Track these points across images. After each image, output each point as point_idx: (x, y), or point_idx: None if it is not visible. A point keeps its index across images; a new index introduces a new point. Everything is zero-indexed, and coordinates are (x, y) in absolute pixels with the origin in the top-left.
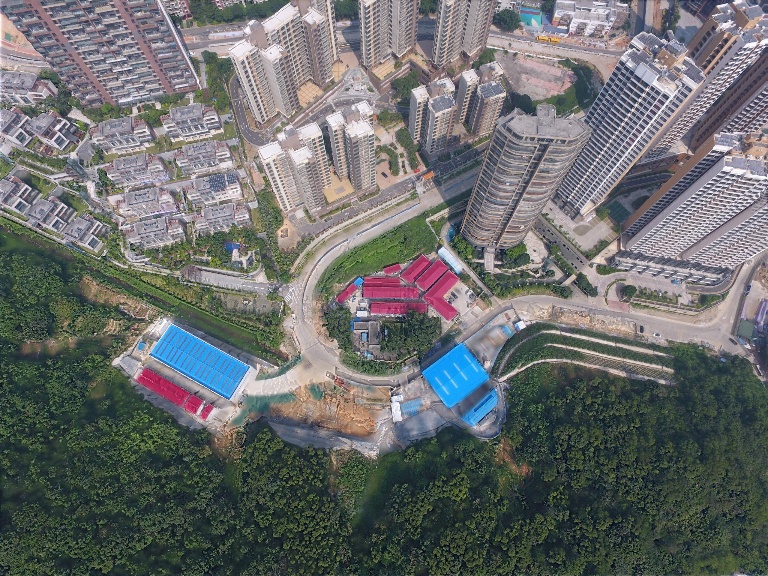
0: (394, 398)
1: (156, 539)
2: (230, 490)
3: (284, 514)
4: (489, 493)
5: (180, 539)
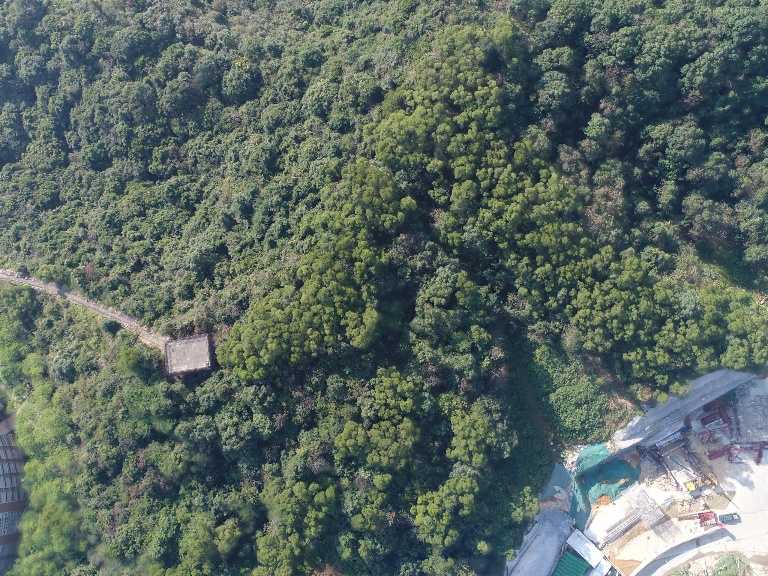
0: (607, 567)
1: (762, 131)
2: (716, 254)
3: (643, 282)
4: (379, 545)
5: (732, 154)
